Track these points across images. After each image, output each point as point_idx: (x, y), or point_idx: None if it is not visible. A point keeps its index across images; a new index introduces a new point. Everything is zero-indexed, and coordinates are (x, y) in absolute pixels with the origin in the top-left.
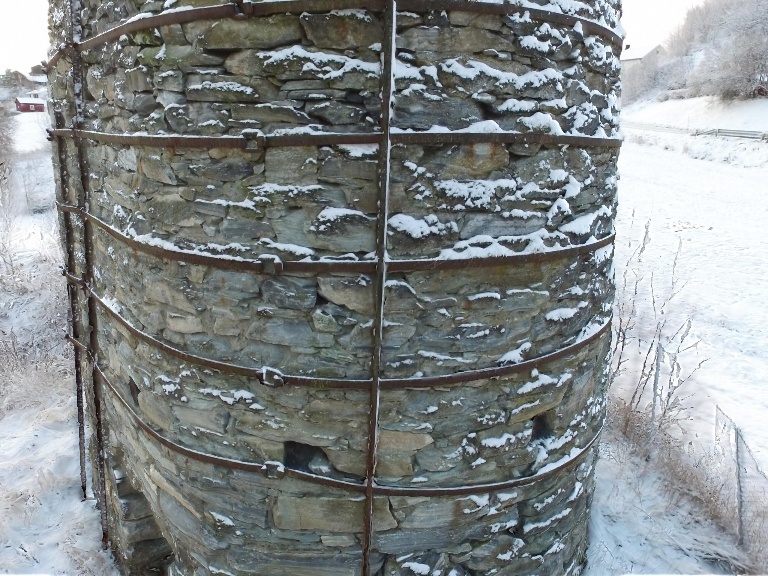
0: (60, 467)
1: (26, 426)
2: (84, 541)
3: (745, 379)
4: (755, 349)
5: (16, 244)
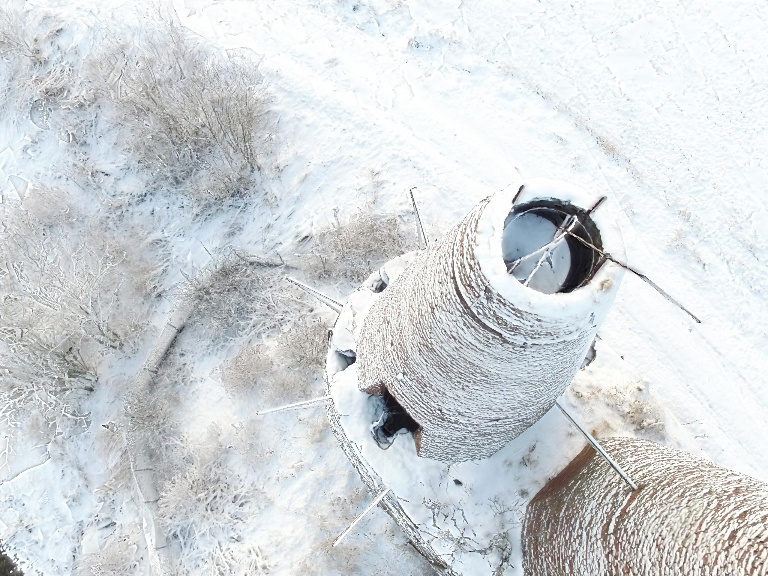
0: (351, 480)
1: (293, 422)
2: (398, 539)
3: (740, 330)
4: (761, 289)
5: (21, 28)
